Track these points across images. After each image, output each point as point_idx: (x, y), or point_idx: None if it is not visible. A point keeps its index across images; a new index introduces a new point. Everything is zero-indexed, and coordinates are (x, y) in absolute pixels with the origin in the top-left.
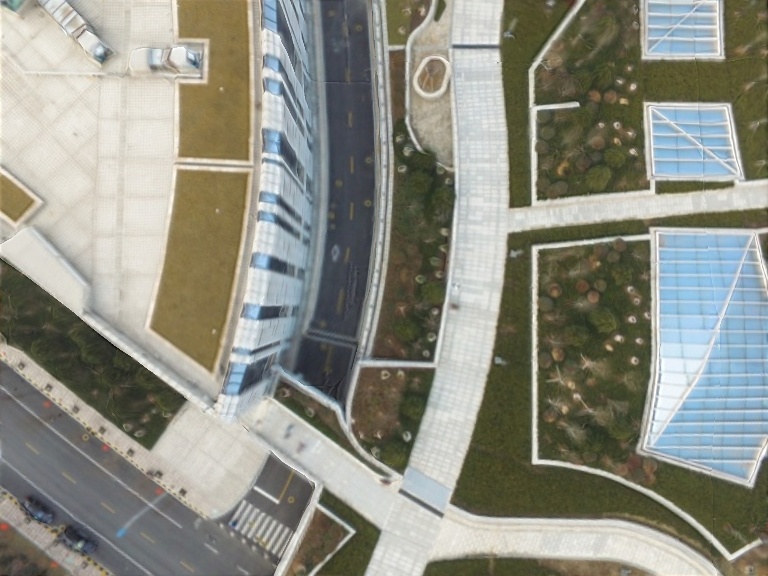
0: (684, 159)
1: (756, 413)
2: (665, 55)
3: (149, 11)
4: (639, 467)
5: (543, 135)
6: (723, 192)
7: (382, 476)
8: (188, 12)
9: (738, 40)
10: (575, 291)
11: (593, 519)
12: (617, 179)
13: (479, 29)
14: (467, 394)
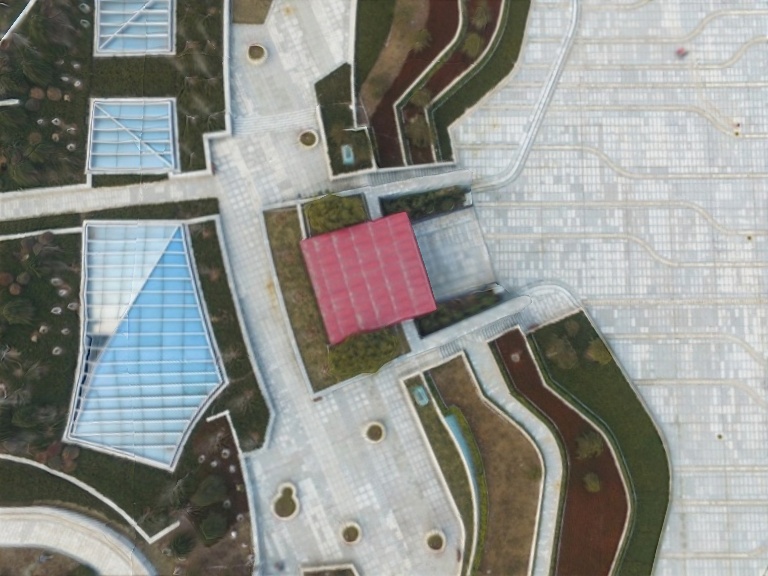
0: (122, 153)
1: (176, 399)
2: (117, 52)
3: None
4: (58, 455)
5: None
6: (160, 185)
7: None
8: None
9: (187, 36)
10: None
11: (21, 507)
12: (43, 174)
13: None
14: None
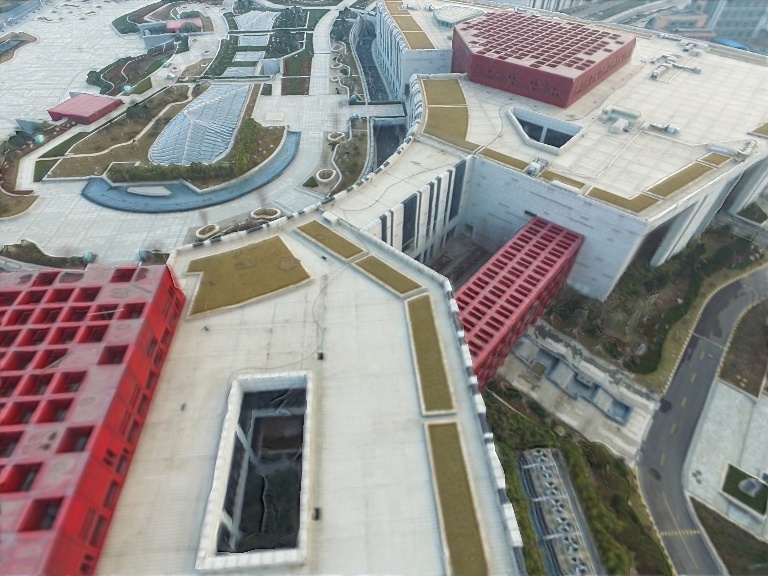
0: None
1: None
2: None
3: None
4: None
5: None
6: None
7: None
8: None
9: None
10: None
11: None
12: None
13: None
14: None
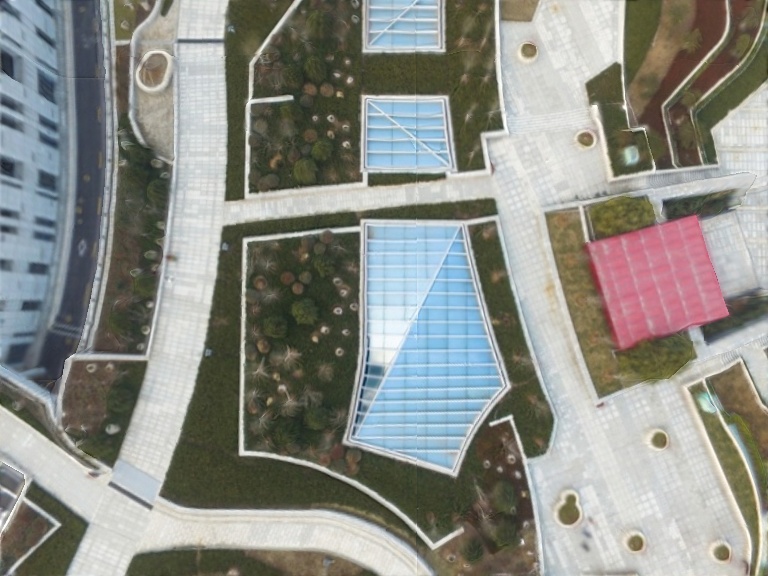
0: (398, 151)
1: (460, 403)
2: (386, 48)
3: None
4: (342, 458)
5: (257, 128)
6: (436, 184)
7: (90, 469)
8: None
9: (458, 33)
10: (280, 283)
11: (300, 510)
12: (324, 171)
13: (205, 24)
14: (179, 387)
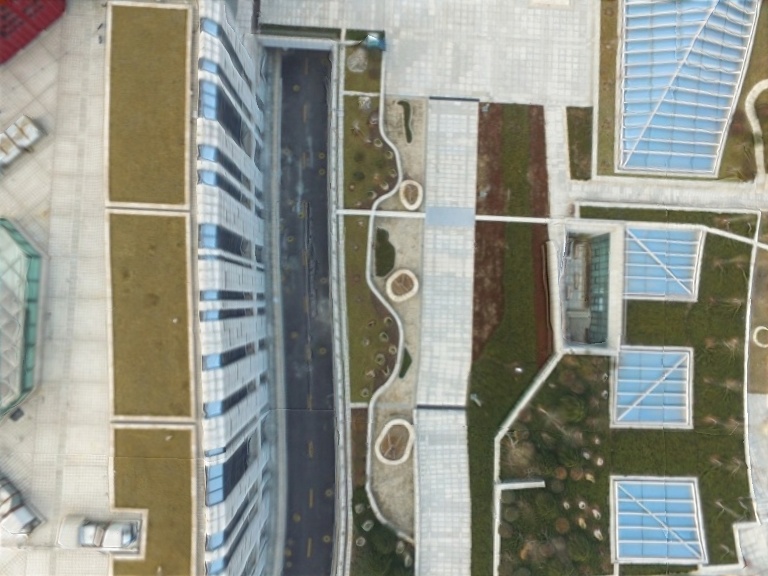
0: (649, 541)
1: None
2: (633, 423)
3: (83, 472)
4: None
5: (507, 516)
6: (686, 575)
7: None
8: (126, 479)
9: (706, 410)
10: None
11: None
12: (580, 571)
13: (445, 388)
14: None
